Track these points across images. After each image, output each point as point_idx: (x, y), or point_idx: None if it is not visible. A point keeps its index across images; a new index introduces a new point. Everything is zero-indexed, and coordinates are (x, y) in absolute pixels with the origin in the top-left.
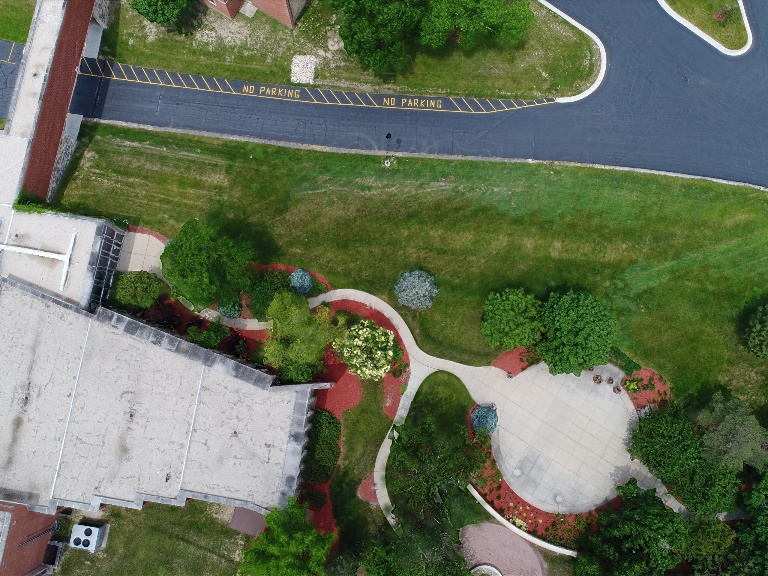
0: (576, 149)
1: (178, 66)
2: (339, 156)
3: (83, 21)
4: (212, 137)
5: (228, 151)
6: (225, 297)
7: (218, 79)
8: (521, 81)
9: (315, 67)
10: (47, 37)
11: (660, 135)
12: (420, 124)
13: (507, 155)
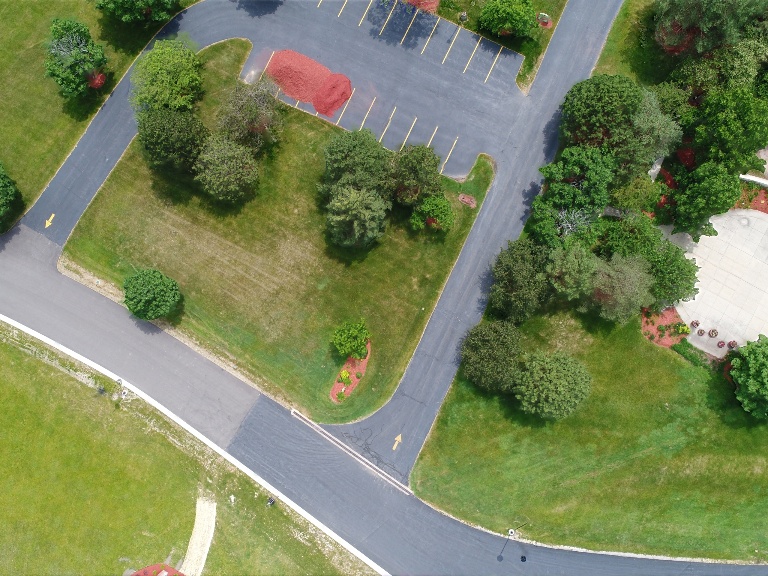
0: None
1: None
2: None
3: None
4: None
5: None
6: None
7: None
8: None
9: None
10: None
11: None
12: None
13: None
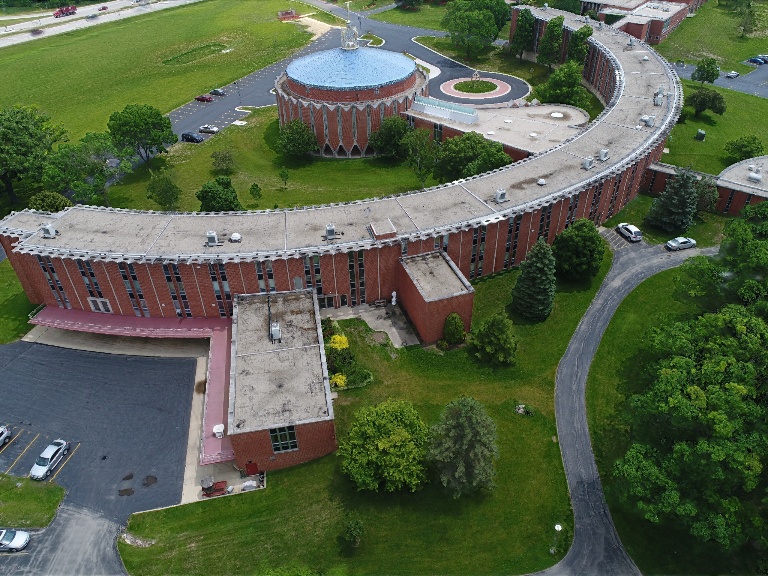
0: None
1: None
2: None
3: None
4: None
5: None
6: None
7: None
8: None
9: None
10: None
11: None
12: None
13: None
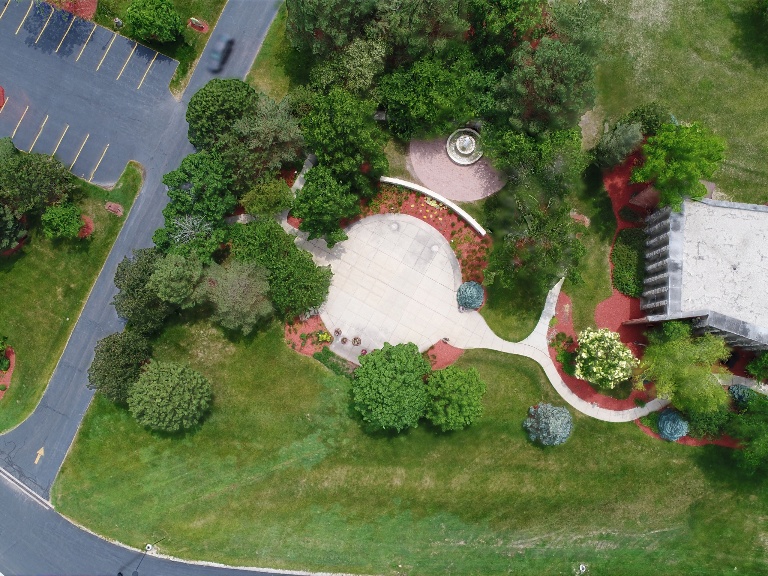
0: None
1: None
2: (637, 575)
3: None
4: None
5: (762, 575)
6: (766, 405)
7: None
8: None
9: None
10: None
11: None
12: None
13: None
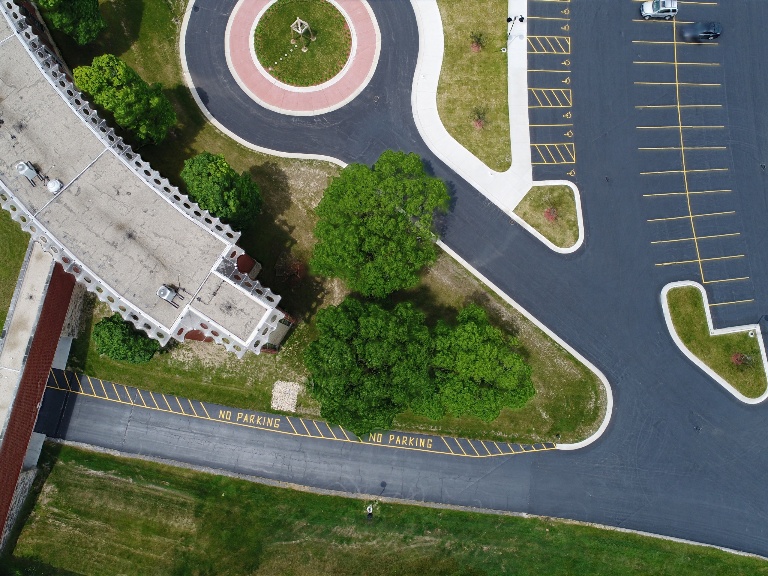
0: (575, 505)
1: (151, 384)
2: (318, 498)
3: (48, 355)
4: (183, 468)
5: (199, 486)
6: None
7: (193, 401)
8: (519, 422)
9: (298, 394)
10: (4, 394)
11: (667, 494)
12: (407, 466)
13: (500, 507)
